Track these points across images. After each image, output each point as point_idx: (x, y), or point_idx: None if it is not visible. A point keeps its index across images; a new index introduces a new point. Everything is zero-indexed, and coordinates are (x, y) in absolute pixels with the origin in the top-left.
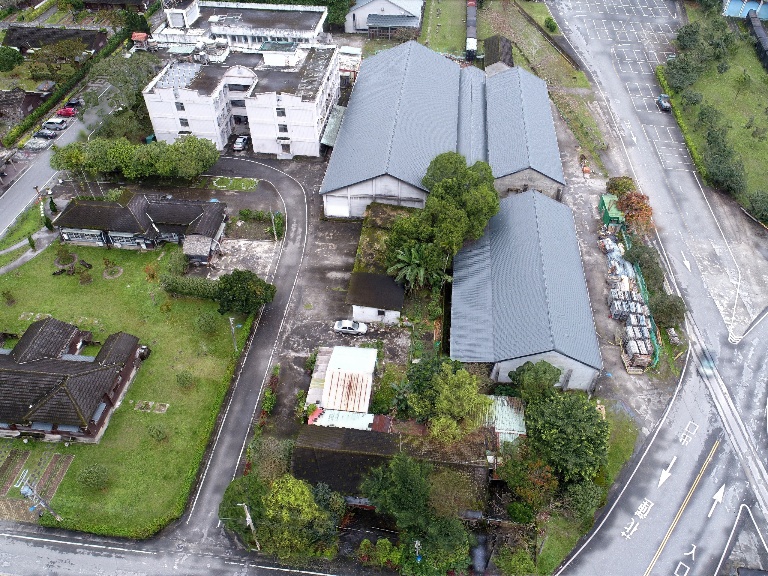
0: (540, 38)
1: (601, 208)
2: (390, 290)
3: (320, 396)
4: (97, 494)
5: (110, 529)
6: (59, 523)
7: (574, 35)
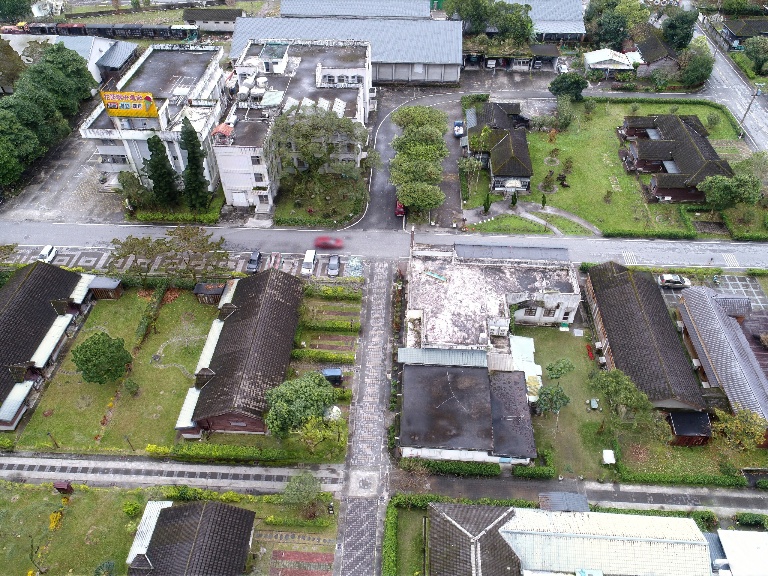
0: (160, 12)
1: (431, 5)
2: (542, 47)
3: (624, 65)
4: (715, 127)
5: (730, 114)
6: (740, 128)
7: (162, 0)
